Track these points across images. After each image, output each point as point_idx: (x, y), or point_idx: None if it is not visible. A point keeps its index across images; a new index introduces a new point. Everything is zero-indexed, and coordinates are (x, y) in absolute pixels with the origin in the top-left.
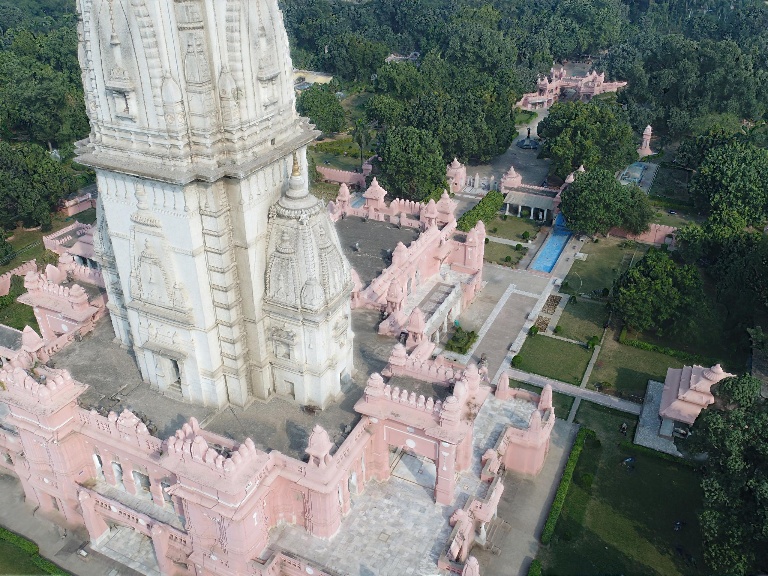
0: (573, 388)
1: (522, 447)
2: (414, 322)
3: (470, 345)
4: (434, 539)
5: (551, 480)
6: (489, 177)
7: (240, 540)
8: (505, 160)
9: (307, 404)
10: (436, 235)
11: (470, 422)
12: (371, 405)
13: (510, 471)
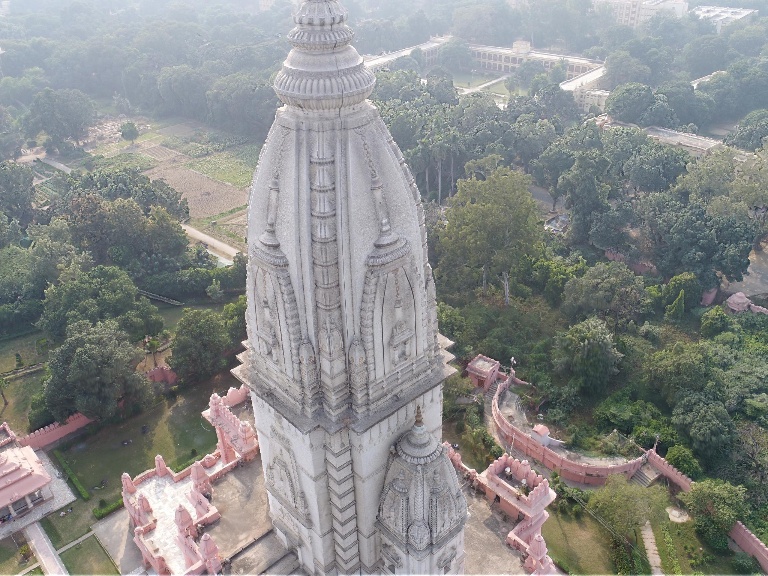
0: (48, 565)
1: None
2: None
3: None
4: None
5: None
6: None
7: None
8: None
9: None
10: None
11: None
12: None
13: None
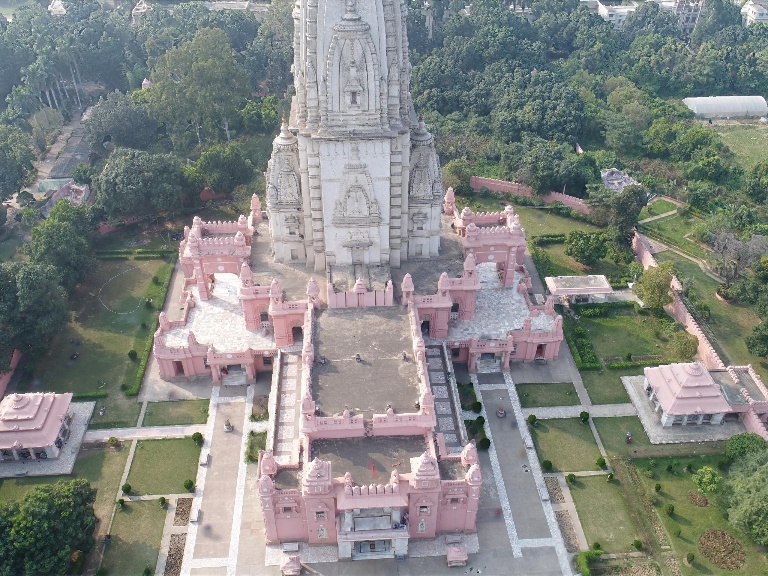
0: (145, 434)
1: None
2: None
3: None
4: None
5: None
6: None
7: None
8: None
9: None
10: (301, 420)
11: None
12: None
13: None
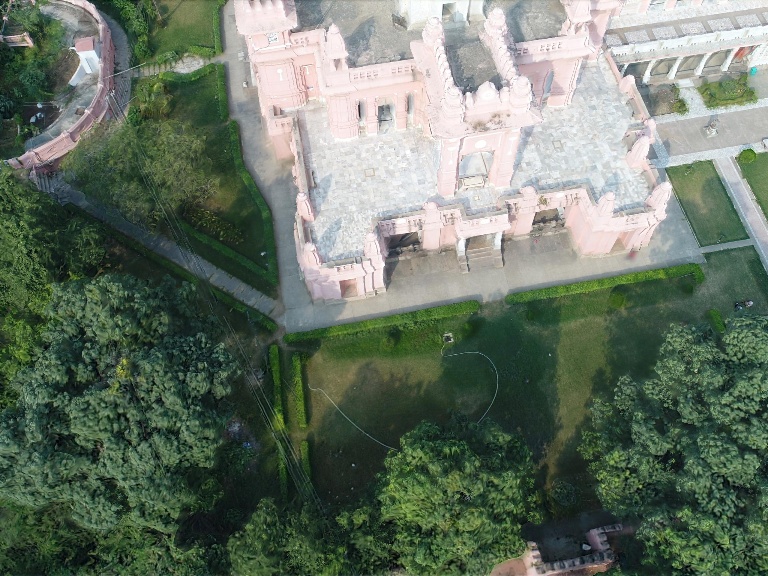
0: (763, 229)
1: (583, 217)
2: (574, 5)
3: (730, 103)
4: (398, 206)
5: (595, 272)
6: None
7: (264, 82)
8: None
9: (403, 15)
10: None
11: (472, 130)
12: (422, 49)
13: (569, 232)
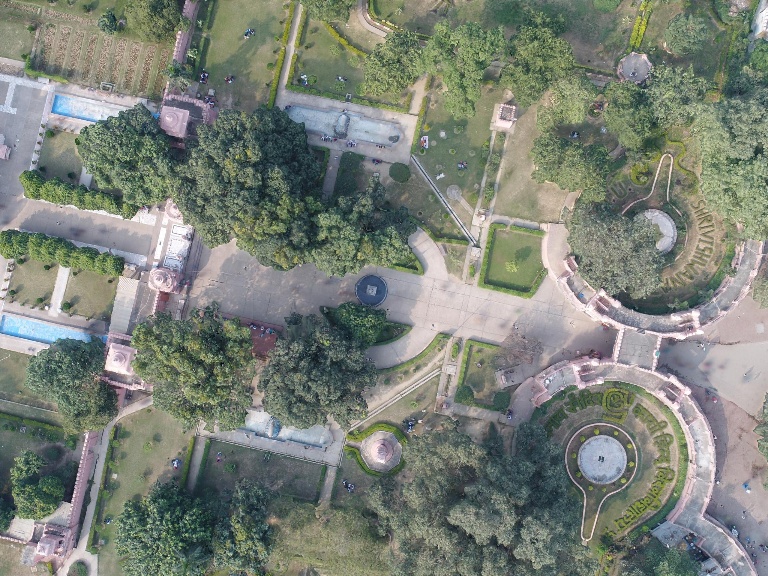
0: None
1: None
2: None
3: None
4: None
5: None
6: (237, 250)
7: None
8: (305, 264)
9: None
10: None
11: None
12: None
13: None
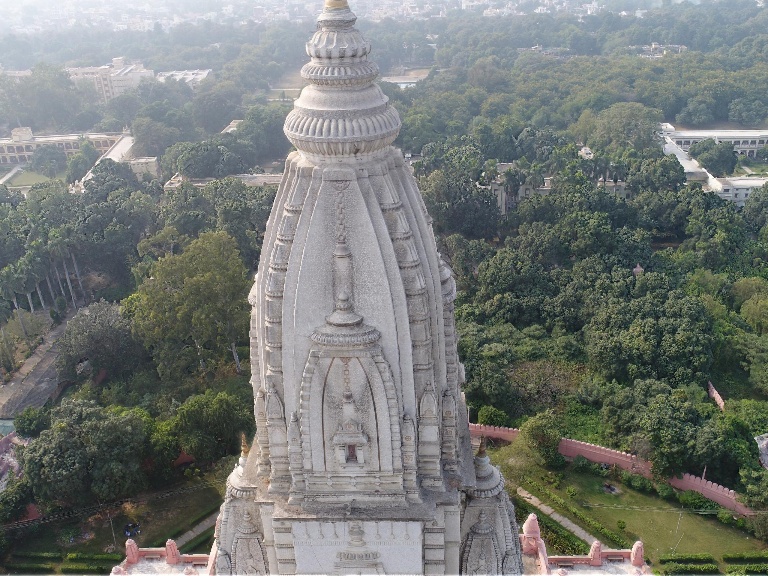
0: None
1: None
2: None
3: None
4: None
5: None
6: None
7: None
8: None
9: None
10: None
11: None
12: None
13: None
